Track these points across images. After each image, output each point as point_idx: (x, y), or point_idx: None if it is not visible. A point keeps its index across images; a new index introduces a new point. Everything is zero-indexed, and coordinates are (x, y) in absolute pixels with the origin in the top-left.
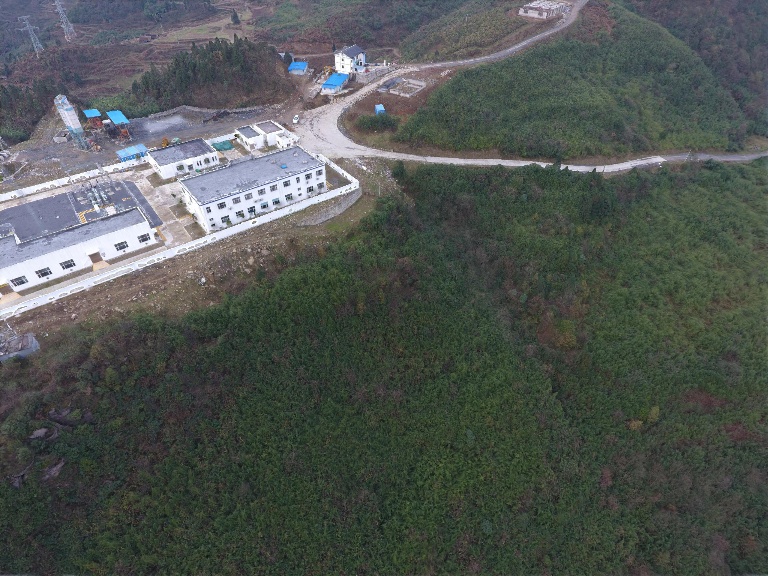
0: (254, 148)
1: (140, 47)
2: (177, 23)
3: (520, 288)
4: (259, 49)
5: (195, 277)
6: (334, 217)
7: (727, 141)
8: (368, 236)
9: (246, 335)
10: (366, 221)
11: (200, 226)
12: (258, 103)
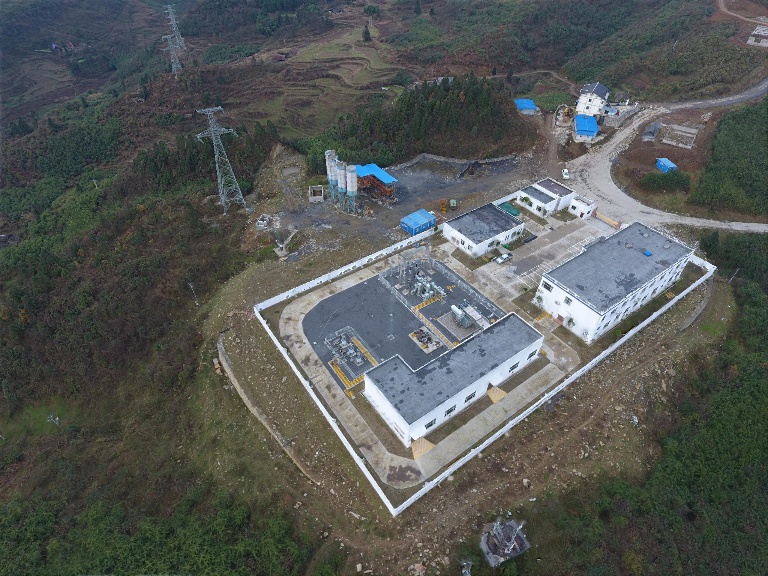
0: (545, 214)
1: (277, 67)
2: (294, 38)
3: None
4: (498, 88)
5: (628, 416)
6: (700, 314)
7: None
8: (758, 342)
9: (708, 498)
10: (749, 322)
11: (571, 332)
12: (506, 151)
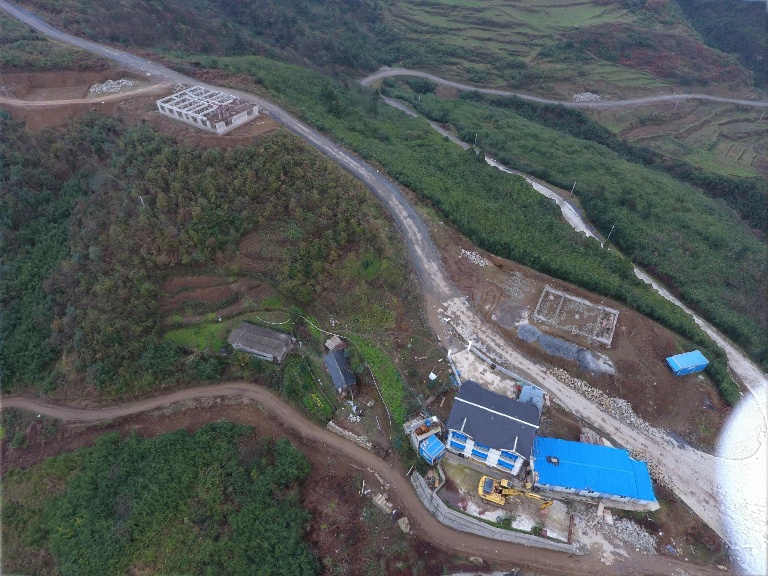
0: None
1: None
2: None
3: (767, 291)
4: None
5: None
6: None
7: (422, 117)
8: None
9: None
10: None
11: None
12: None
